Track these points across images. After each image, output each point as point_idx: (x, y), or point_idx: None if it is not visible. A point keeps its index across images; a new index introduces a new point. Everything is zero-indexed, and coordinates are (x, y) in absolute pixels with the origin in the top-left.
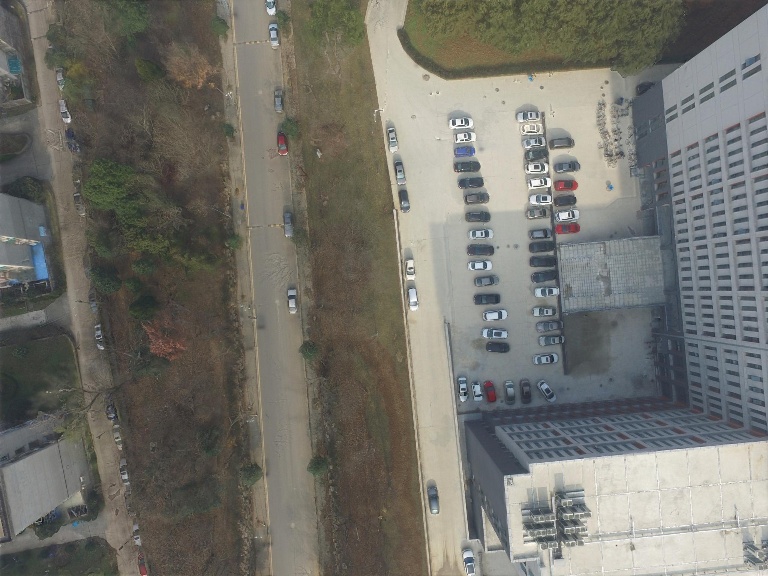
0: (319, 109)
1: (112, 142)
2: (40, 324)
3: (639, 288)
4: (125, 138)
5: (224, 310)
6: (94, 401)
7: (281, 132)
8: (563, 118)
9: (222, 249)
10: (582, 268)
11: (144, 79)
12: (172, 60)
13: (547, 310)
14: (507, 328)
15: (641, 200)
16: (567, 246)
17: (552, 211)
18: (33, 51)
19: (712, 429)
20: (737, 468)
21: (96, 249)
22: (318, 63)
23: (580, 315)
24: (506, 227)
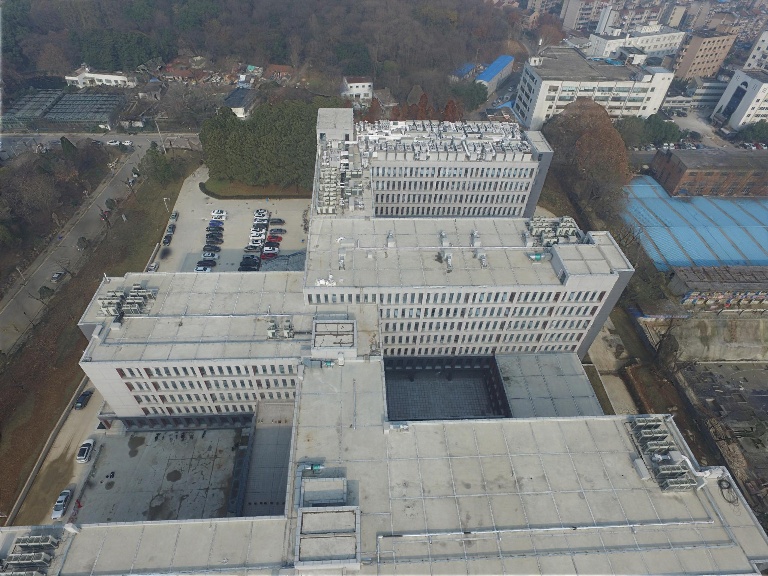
0: (138, 206)
1: None
2: None
3: None
4: (5, 184)
5: (5, 276)
6: None
7: (108, 210)
8: (282, 215)
9: (30, 250)
10: None
11: None
12: (57, 166)
13: None
14: None
15: None
16: None
17: None
18: None
19: None
20: (277, 285)
21: None
22: (149, 191)
23: None
24: (229, 255)
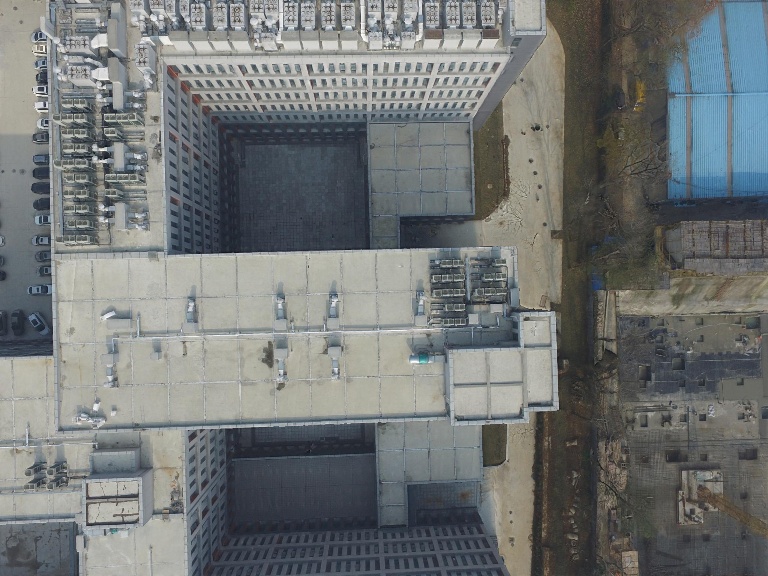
0: None
1: None
2: None
3: None
4: None
5: None
6: None
7: None
8: None
9: None
10: None
11: None
12: None
13: (42, 238)
14: (6, 256)
15: None
16: None
17: None
18: None
19: None
20: (33, 383)
21: None
22: None
23: None
24: (13, 151)
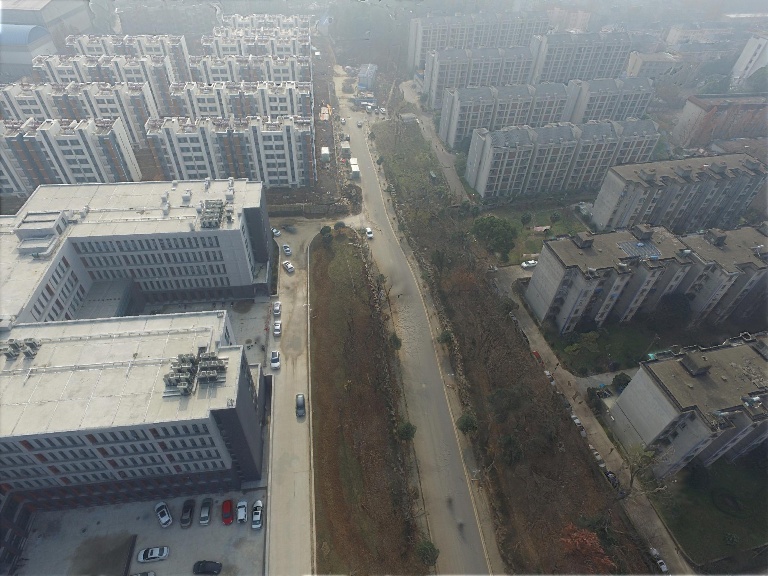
0: None
1: None
2: None
3: None
4: None
5: None
6: (631, 483)
7: None
8: None
9: None
10: None
11: None
12: None
13: None
14: None
15: None
16: None
17: None
18: None
19: (3, 461)
20: (2, 417)
21: None
22: None
23: None
24: None
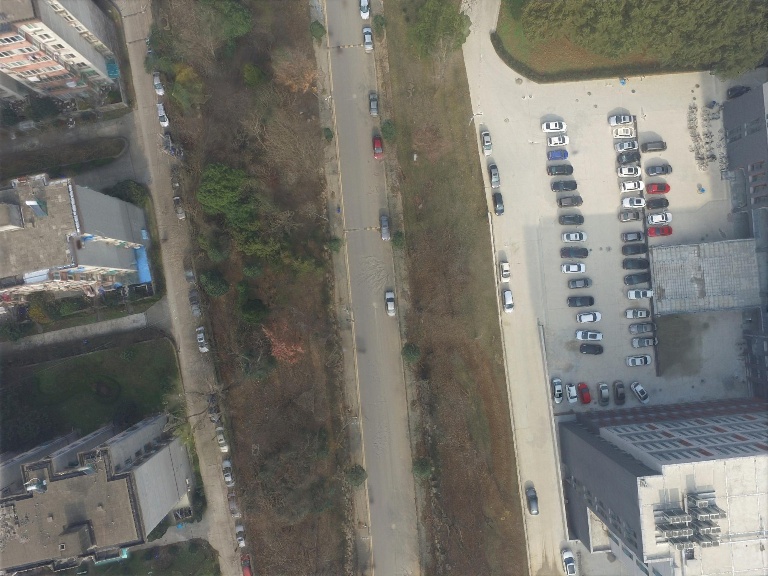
0: (413, 113)
1: (224, 146)
2: (140, 327)
3: (735, 290)
4: (238, 142)
5: (324, 313)
6: (209, 404)
7: (377, 136)
8: (654, 121)
9: (321, 252)
10: (676, 270)
11: (250, 83)
12: (282, 65)
13: (641, 312)
14: (600, 330)
15: (732, 203)
16: (660, 249)
17: (644, 214)
18: (128, 55)
19: None
20: None
21: (209, 253)
22: (412, 67)
23: (672, 317)
24: (599, 230)
